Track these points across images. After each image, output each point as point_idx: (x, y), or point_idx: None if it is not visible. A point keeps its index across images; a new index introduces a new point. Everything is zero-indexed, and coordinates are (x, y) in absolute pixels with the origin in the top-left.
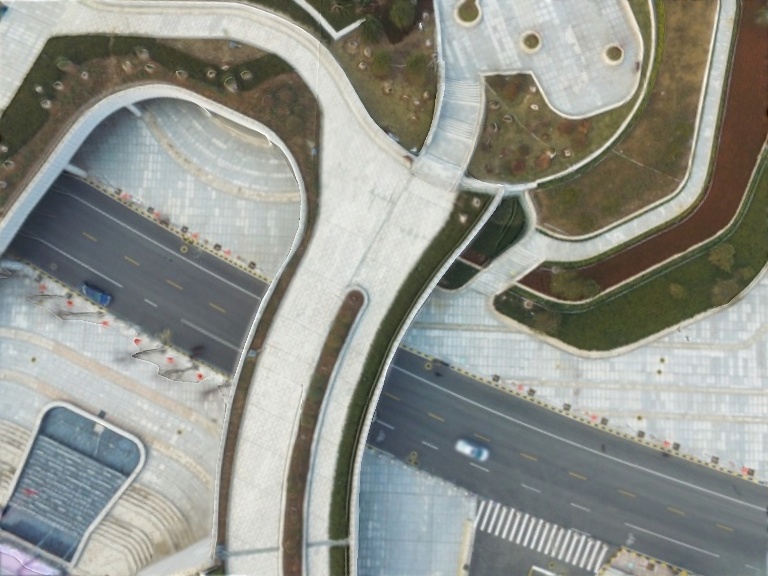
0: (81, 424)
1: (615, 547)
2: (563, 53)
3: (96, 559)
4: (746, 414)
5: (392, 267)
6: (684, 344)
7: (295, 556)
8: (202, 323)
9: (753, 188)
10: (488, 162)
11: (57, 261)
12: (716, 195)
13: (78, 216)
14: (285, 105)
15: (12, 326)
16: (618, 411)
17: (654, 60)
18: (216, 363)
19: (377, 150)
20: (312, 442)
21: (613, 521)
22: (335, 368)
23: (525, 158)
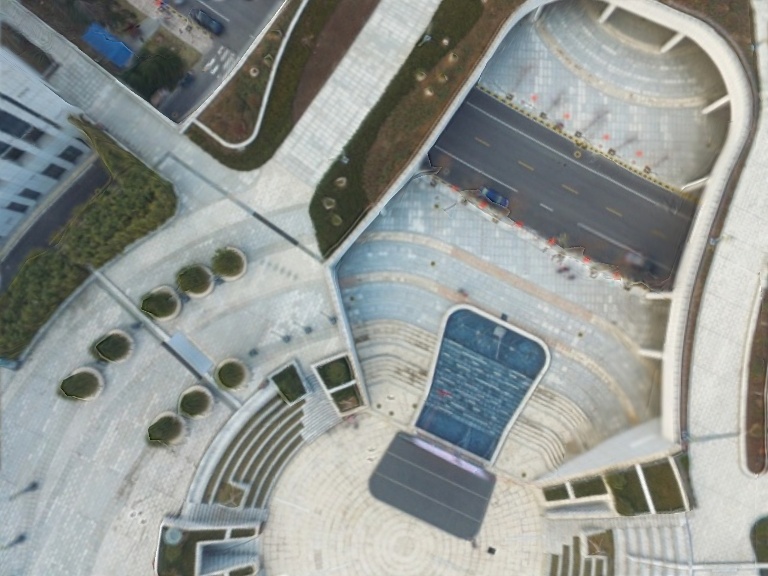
0: (482, 327)
1: None
2: None
3: (513, 458)
4: None
5: None
6: None
7: (761, 439)
8: (599, 227)
9: None
10: None
11: (450, 166)
12: None
13: (470, 121)
14: (722, 1)
15: (409, 230)
16: None
17: None
18: None
19: None
20: None
21: None
22: None
23: None
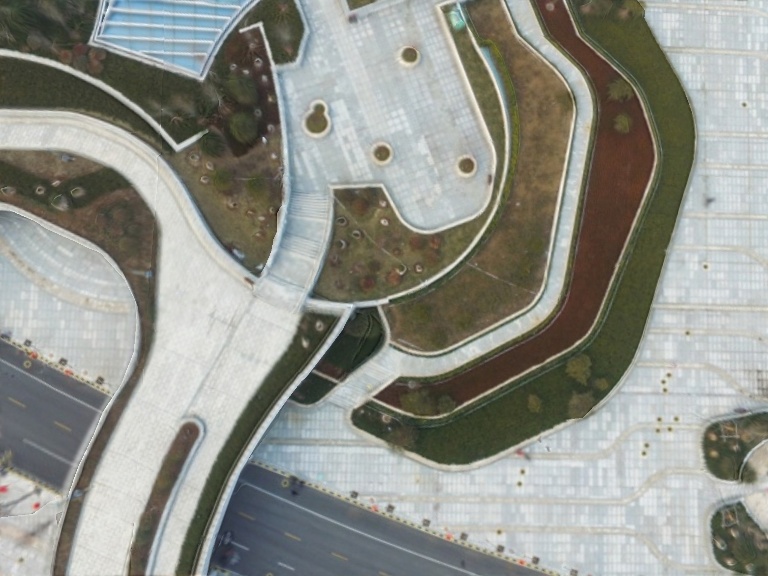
0: None
1: None
2: (416, 164)
3: None
4: (605, 525)
5: (231, 395)
6: (545, 455)
7: None
8: (46, 443)
9: (612, 296)
10: (338, 278)
11: None
12: (573, 305)
13: None
14: (119, 224)
15: None
16: (478, 525)
17: (508, 172)
18: (61, 485)
19: (218, 270)
20: None
21: None
22: (167, 506)
23: (376, 274)
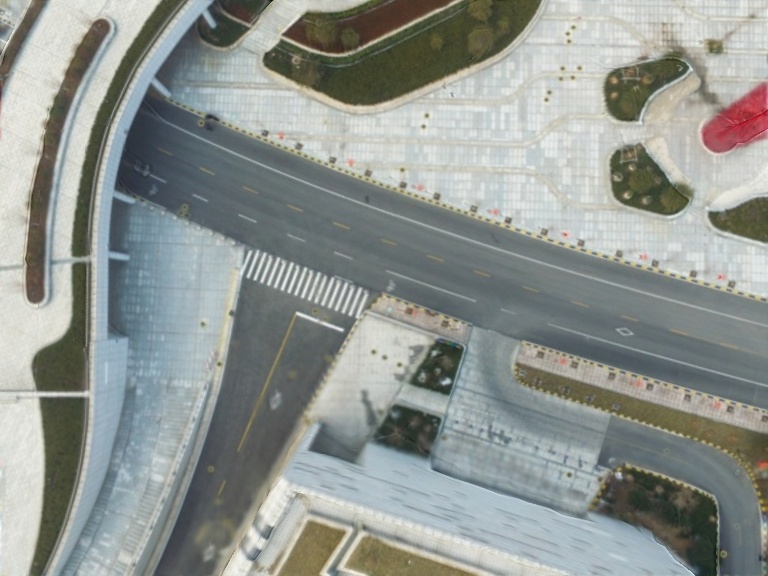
0: None
1: (376, 293)
2: None
3: None
4: (506, 165)
5: (141, 1)
6: (449, 100)
7: (36, 269)
8: None
9: None
10: None
11: None
12: None
13: None
14: None
15: None
16: (382, 163)
17: None
18: None
19: None
20: (56, 162)
21: (375, 268)
22: (79, 91)
23: None
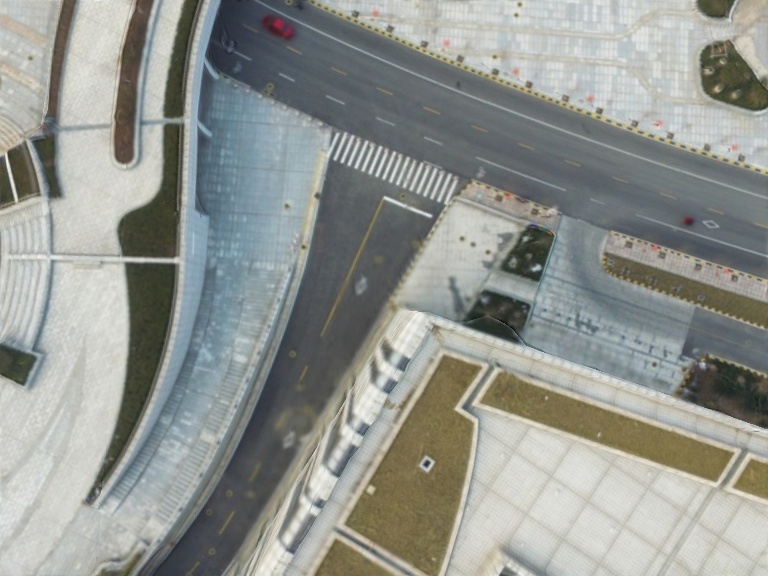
0: None
1: (465, 179)
2: None
3: None
4: (597, 57)
5: None
6: None
7: (126, 127)
8: None
9: None
10: None
11: None
12: None
13: None
14: None
15: None
16: (474, 50)
17: None
18: None
19: None
20: (150, 17)
21: (465, 155)
22: None
23: None
